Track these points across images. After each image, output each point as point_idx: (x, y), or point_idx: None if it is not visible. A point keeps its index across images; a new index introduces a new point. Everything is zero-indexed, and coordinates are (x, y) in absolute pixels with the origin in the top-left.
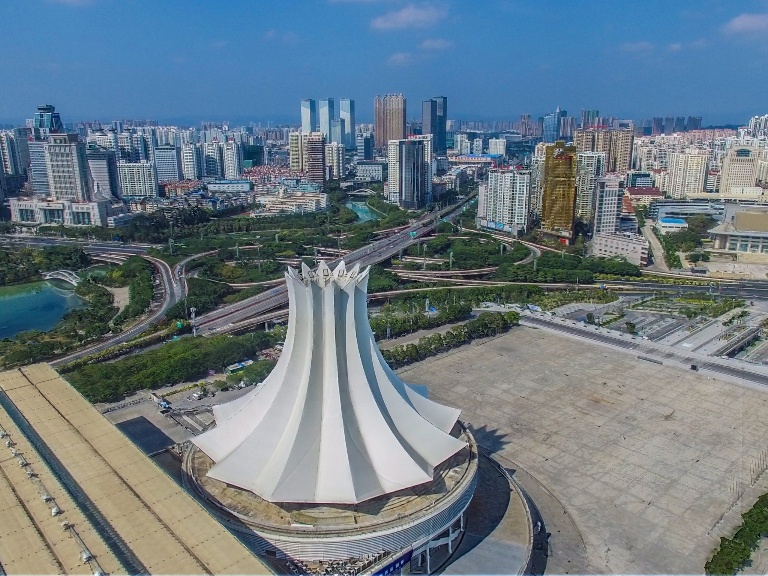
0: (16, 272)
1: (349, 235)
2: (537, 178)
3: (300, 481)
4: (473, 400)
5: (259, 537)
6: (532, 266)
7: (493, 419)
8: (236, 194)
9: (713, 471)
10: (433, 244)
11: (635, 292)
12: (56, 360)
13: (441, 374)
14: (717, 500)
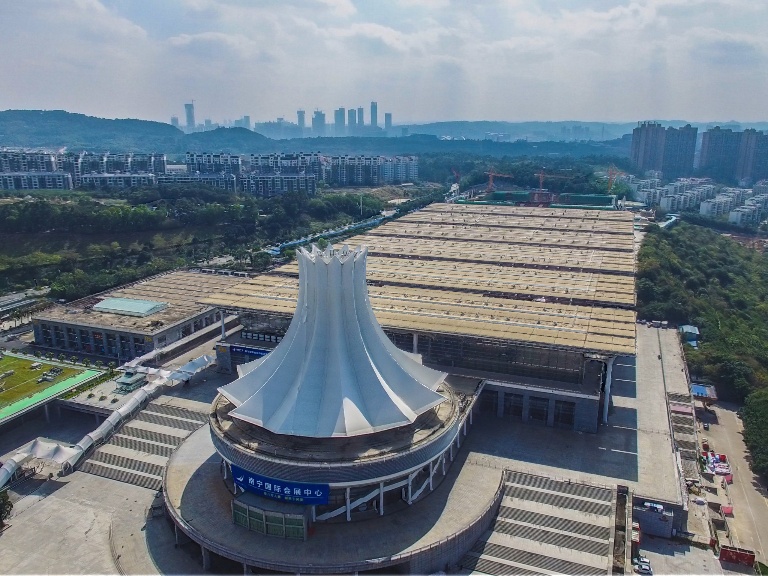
0: None
1: None
2: None
3: None
4: None
5: None
6: None
7: None
8: None
9: None
10: None
11: None
12: None
13: None
14: None
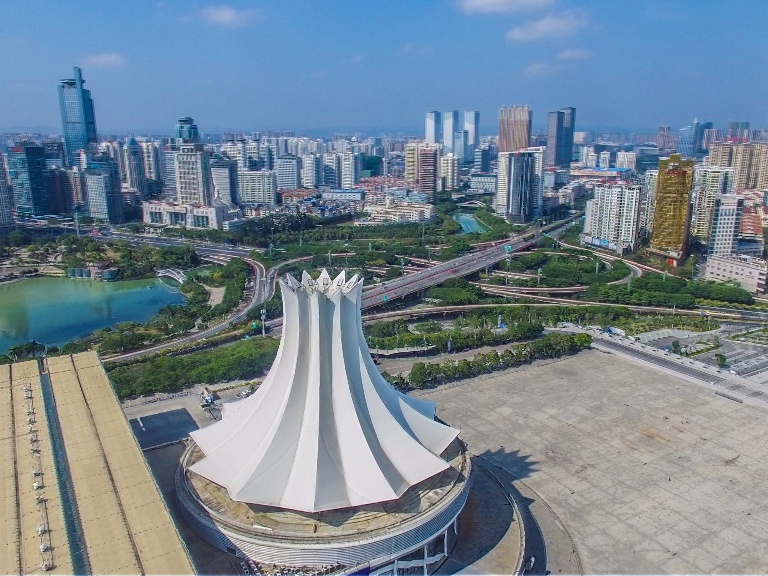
0: (134, 268)
1: (445, 247)
2: (648, 194)
3: (269, 484)
4: (514, 422)
5: (222, 533)
6: (626, 287)
7: (529, 444)
8: (346, 203)
9: (764, 528)
10: (527, 259)
11: (742, 321)
12: (142, 350)
13: (489, 393)
14: (758, 561)
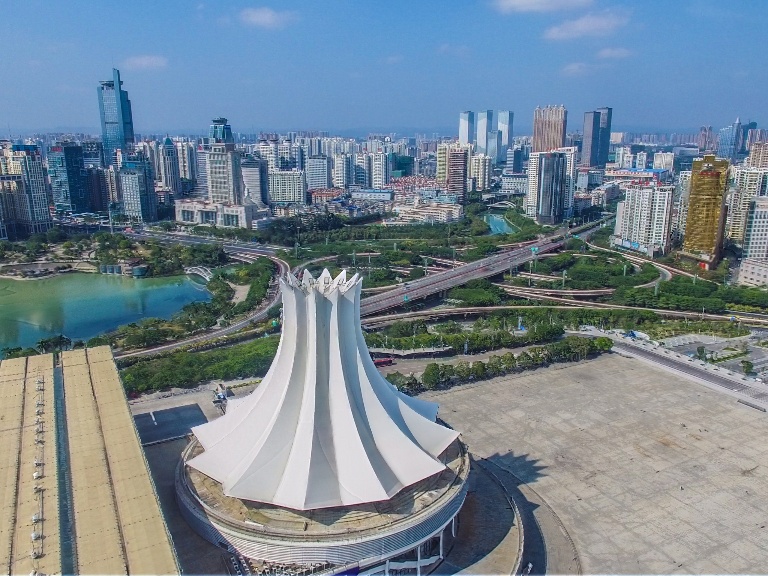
0: (163, 266)
1: (471, 247)
2: (680, 195)
3: (263, 481)
4: (525, 426)
5: (214, 528)
6: (653, 290)
7: (539, 448)
8: (374, 203)
9: None
10: (554, 261)
11: None
12: (164, 346)
13: (503, 395)
14: (767, 575)
